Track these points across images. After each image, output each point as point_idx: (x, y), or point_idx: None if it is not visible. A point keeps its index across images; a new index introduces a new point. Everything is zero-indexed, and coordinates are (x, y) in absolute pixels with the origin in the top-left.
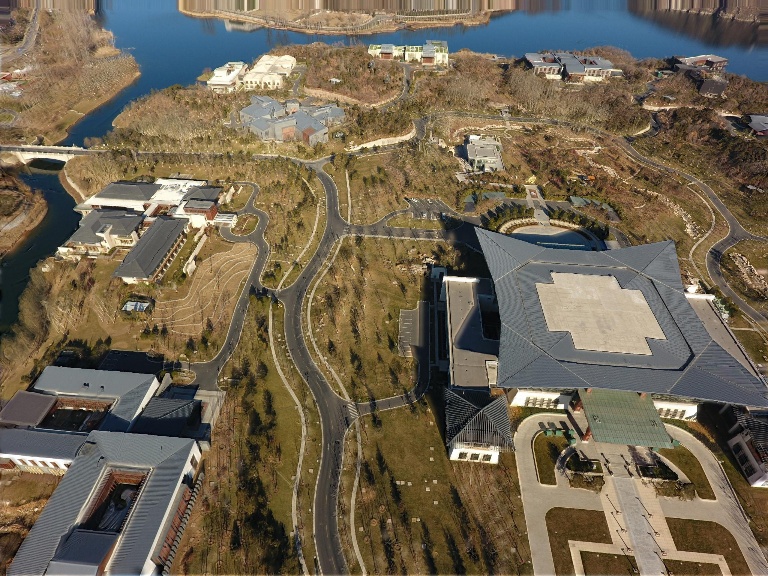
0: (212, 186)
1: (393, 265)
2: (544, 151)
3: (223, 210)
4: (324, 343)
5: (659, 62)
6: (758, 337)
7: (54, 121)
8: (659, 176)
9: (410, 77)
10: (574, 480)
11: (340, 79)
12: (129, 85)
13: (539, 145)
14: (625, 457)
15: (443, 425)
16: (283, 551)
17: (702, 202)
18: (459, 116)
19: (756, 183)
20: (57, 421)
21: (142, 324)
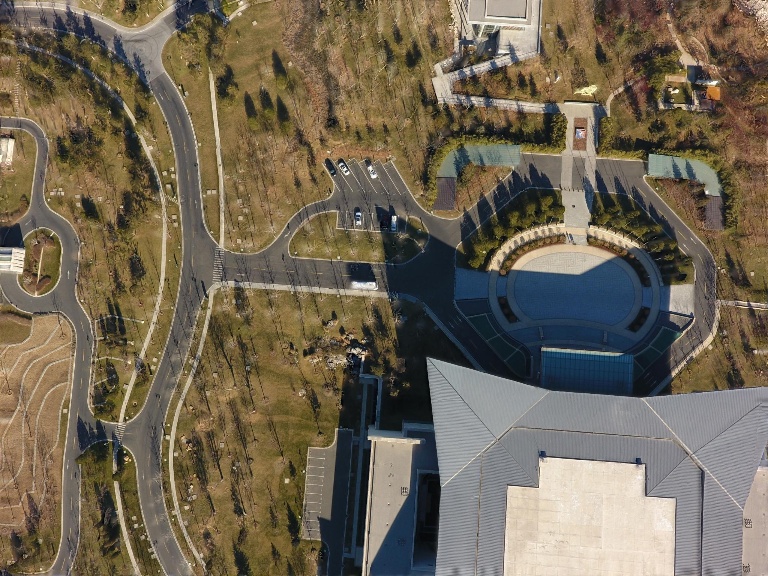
0: None
1: (299, 355)
2: None
3: None
4: (197, 531)
5: None
6: None
7: None
8: None
9: None
10: None
11: None
12: None
13: None
14: None
15: None
16: None
17: None
18: None
19: None
20: None
21: None
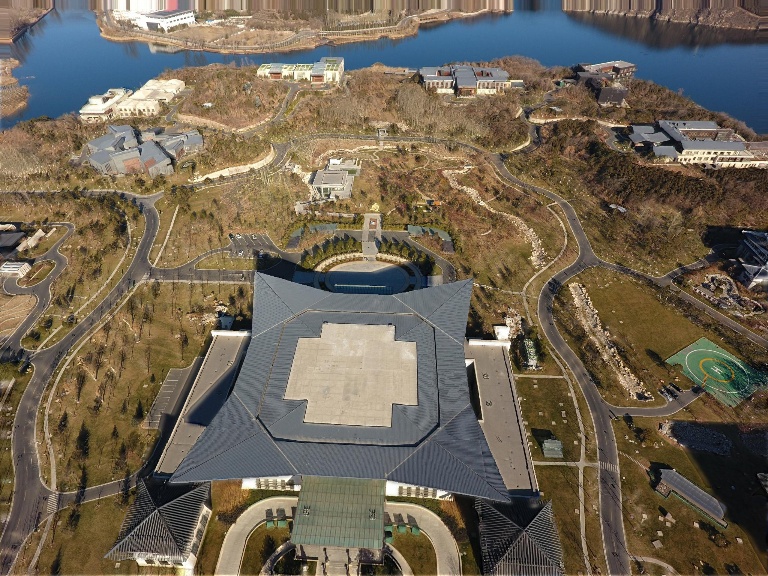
0: (20, 230)
1: (183, 315)
2: (405, 174)
3: (20, 257)
4: (57, 416)
5: (565, 70)
6: (564, 386)
7: None
8: (519, 197)
9: (292, 98)
10: None
11: (213, 103)
12: (7, 117)
13: (406, 166)
14: (350, 552)
15: None
16: None
17: (558, 225)
18: (330, 138)
19: (620, 201)
20: None
21: None
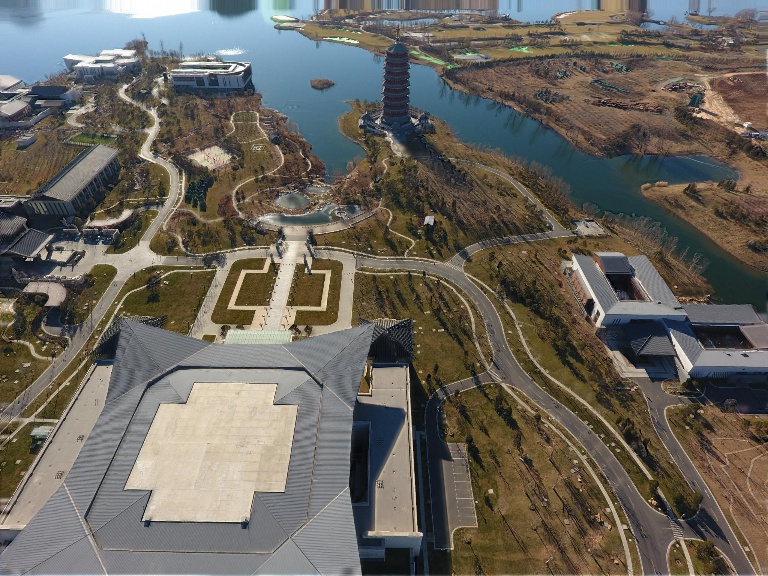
0: None
1: None
2: None
3: None
4: (558, 443)
5: None
6: None
7: None
8: None
9: None
10: None
11: None
12: None
13: None
14: None
15: (410, 370)
16: None
17: None
18: None
19: None
20: (736, 343)
21: None
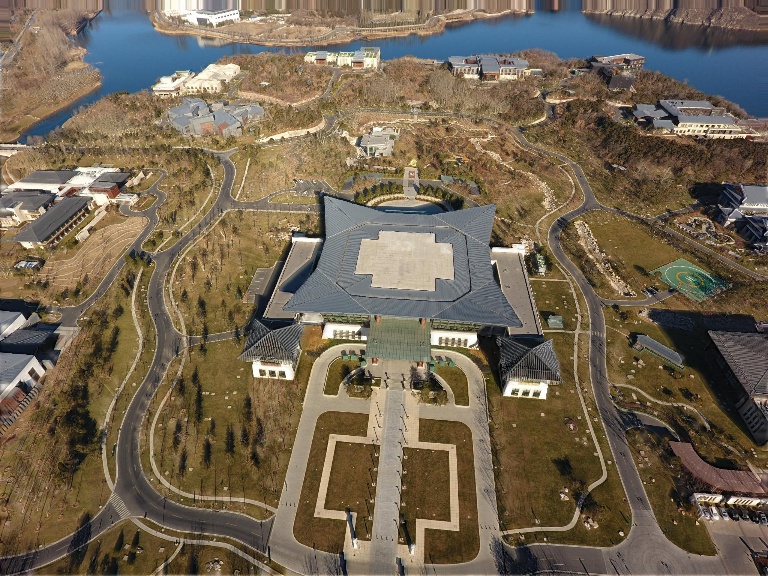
0: (125, 172)
1: (263, 233)
2: None
3: (128, 191)
4: (179, 292)
5: (580, 61)
6: (567, 286)
7: (10, 124)
8: (535, 158)
9: (336, 79)
10: (347, 389)
11: (269, 82)
12: (88, 94)
13: (437, 135)
14: (405, 375)
15: None
16: (89, 438)
17: (568, 180)
18: (372, 112)
19: (621, 162)
20: None
21: (29, 279)
